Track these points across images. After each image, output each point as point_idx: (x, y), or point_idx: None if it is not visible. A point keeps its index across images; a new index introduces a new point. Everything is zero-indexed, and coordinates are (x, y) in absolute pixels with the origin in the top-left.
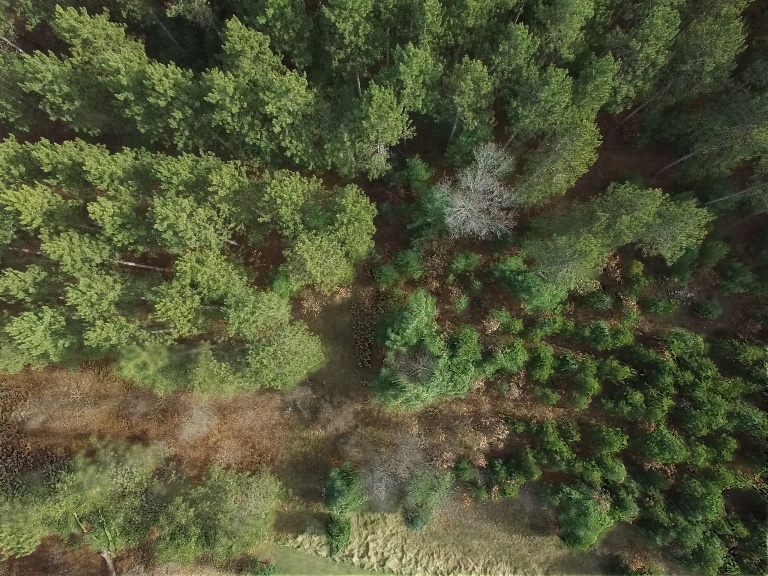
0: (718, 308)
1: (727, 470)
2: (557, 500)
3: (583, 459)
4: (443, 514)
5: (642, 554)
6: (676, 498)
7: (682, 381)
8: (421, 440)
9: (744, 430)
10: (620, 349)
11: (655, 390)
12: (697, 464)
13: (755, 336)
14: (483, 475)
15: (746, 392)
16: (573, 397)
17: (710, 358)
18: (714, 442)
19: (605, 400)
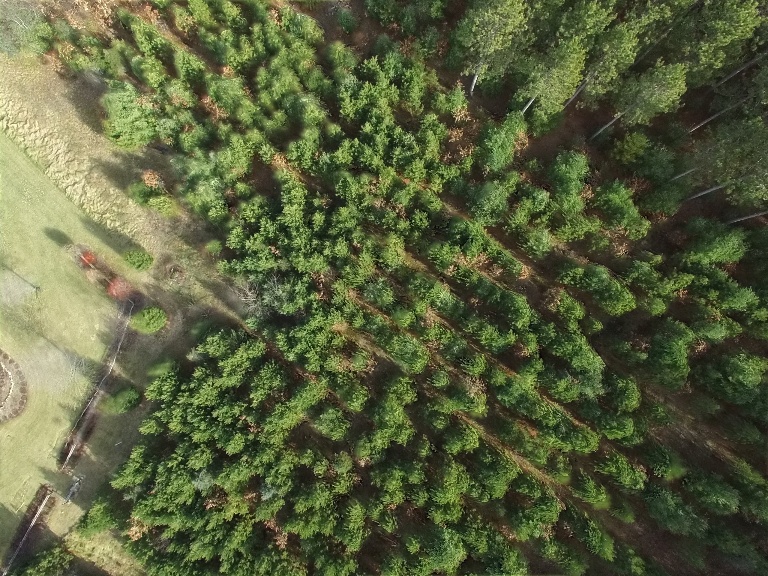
0: (364, 30)
1: (265, 137)
2: (110, 80)
3: (161, 73)
4: (38, 76)
5: (162, 176)
6: (216, 146)
7: (270, 39)
8: (55, 4)
9: (299, 112)
10: (251, 4)
11: (246, 38)
12: (244, 119)
13: (365, 50)
14: (69, 35)
15: (327, 90)
16: (177, 8)
17: (316, 48)
18: (272, 113)
19: (204, 29)
